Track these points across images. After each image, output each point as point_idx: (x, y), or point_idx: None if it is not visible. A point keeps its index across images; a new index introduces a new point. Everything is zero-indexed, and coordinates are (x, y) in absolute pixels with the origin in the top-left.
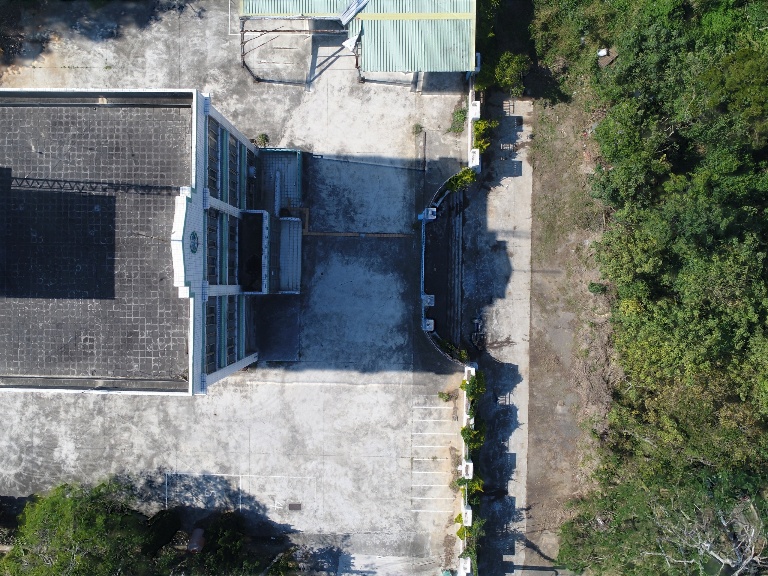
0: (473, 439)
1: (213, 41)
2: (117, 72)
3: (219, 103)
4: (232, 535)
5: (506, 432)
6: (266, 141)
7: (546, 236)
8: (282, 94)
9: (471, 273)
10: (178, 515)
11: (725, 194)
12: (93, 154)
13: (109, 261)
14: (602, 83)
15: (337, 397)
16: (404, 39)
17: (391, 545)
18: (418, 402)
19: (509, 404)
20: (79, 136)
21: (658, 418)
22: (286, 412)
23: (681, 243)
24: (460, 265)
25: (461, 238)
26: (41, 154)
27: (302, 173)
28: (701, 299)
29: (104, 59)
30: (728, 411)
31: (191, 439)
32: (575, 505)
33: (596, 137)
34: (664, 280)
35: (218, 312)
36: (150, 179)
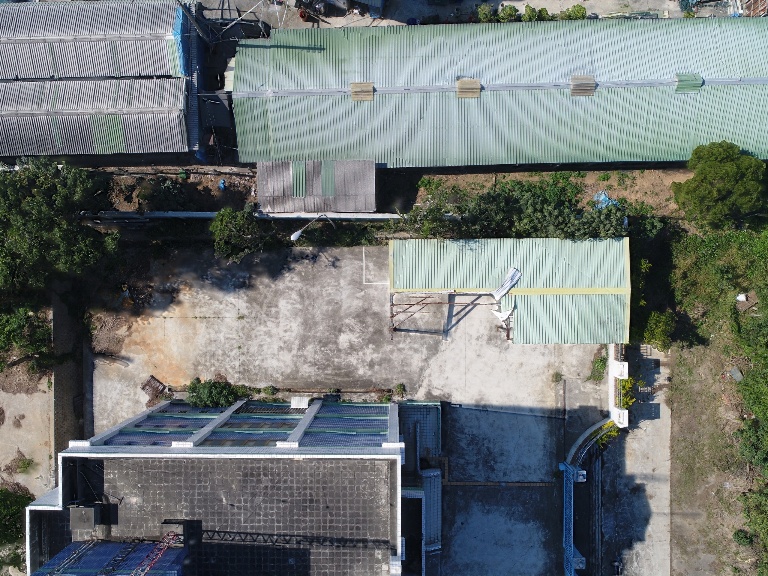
0: None
1: (348, 290)
2: (250, 322)
3: (355, 353)
4: None
5: None
6: (404, 391)
7: (685, 478)
8: (419, 343)
9: (610, 516)
10: None
11: None
12: (286, 506)
13: None
14: (749, 341)
15: None
16: (557, 313)
17: None
18: None
19: None
20: (271, 488)
21: None
22: None
23: None
24: (600, 509)
25: (600, 482)
26: (232, 506)
27: (441, 422)
28: None
29: (236, 309)
30: None
31: None
32: None
33: (741, 390)
34: None
35: None
36: (345, 531)
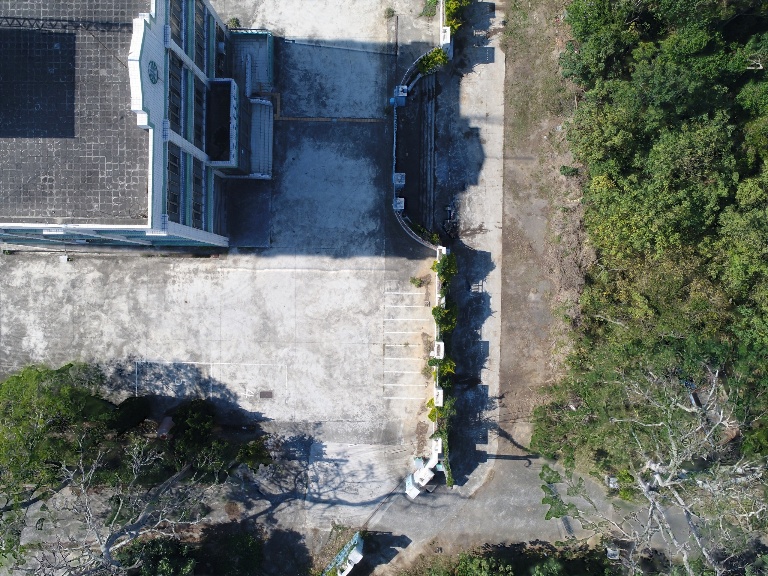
0: (444, 320)
1: None
2: None
3: None
4: (201, 417)
5: (479, 320)
6: (237, 25)
7: (519, 123)
8: None
9: (444, 160)
10: (148, 403)
11: (696, 78)
12: None
13: (69, 99)
14: None
15: (309, 283)
16: None
17: (363, 433)
18: (390, 288)
19: (482, 292)
20: None
21: (629, 298)
22: (257, 299)
23: (650, 110)
24: (433, 152)
25: (434, 125)
26: None
27: (274, 58)
28: (671, 173)
29: None
30: (698, 284)
31: (161, 327)
32: (548, 393)
33: (567, 18)
34: (635, 159)
35: (183, 169)
36: (110, 16)
